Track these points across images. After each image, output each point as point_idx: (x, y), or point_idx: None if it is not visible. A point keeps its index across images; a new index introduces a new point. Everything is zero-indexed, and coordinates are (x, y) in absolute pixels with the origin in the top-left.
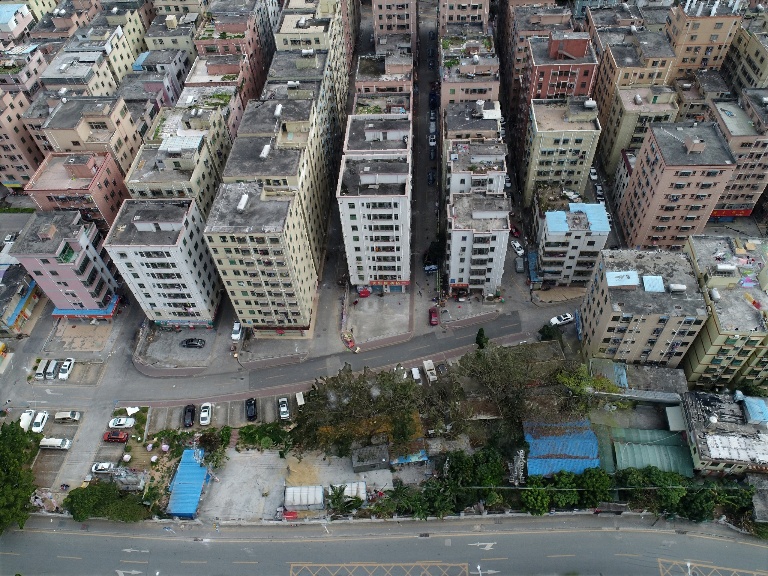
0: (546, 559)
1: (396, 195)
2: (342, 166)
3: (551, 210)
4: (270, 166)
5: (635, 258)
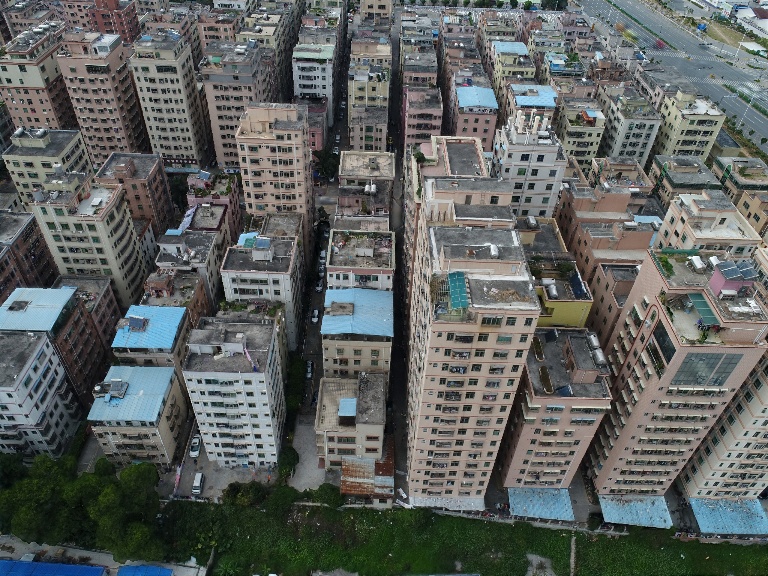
0: None
1: None
2: None
3: None
4: None
5: None
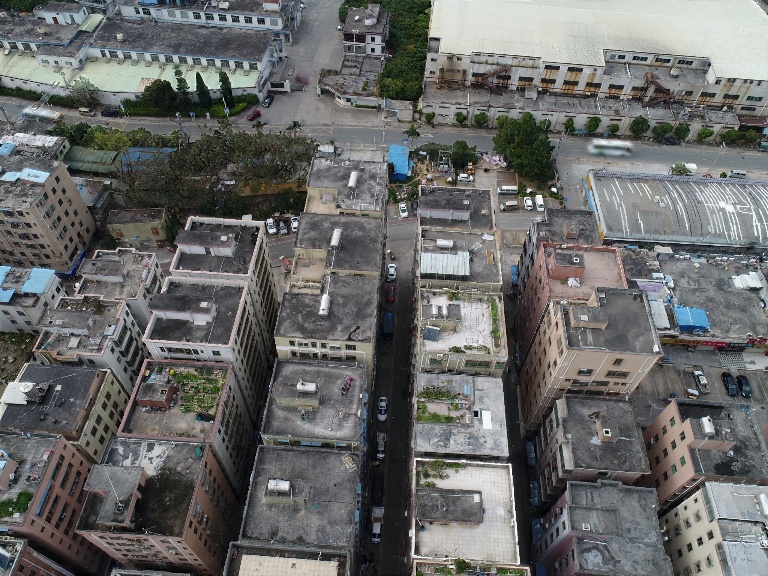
0: (186, 131)
1: (201, 218)
2: (253, 259)
3: (31, 307)
4: (331, 228)
5: (5, 199)
